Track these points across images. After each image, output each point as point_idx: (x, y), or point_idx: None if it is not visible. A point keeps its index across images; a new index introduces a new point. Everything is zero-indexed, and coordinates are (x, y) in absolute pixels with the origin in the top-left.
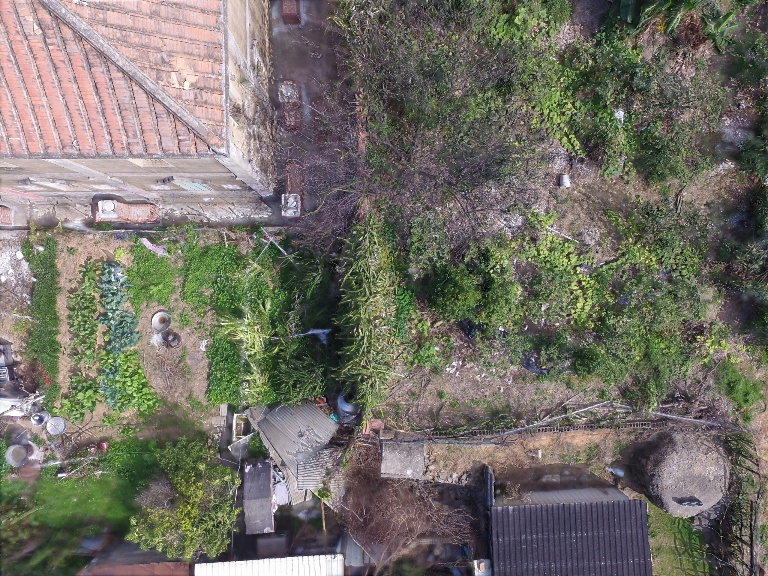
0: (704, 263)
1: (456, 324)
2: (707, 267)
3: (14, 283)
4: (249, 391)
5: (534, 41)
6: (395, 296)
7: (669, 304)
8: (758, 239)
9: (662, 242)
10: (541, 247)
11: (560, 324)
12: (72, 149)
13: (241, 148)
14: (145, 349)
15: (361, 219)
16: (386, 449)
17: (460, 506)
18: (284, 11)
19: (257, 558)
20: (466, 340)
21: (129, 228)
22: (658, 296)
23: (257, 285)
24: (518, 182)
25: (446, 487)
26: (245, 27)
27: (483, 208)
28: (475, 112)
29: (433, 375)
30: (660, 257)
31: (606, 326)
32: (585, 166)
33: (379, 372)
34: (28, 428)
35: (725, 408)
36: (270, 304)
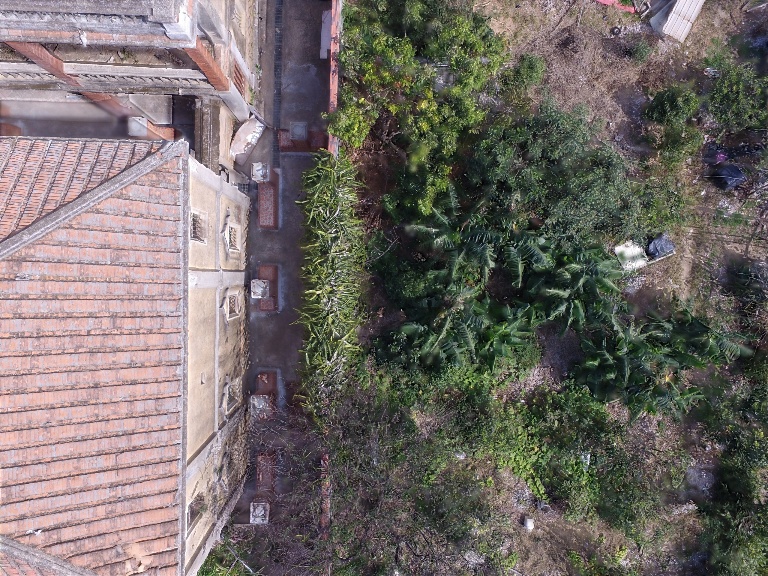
0: None
1: None
2: None
3: None
4: None
5: (504, 384)
6: None
7: None
8: None
9: None
10: None
11: None
12: None
13: (204, 532)
14: None
15: None
16: None
17: None
18: (261, 307)
19: None
20: None
21: None
22: None
23: None
24: None
25: None
26: (214, 396)
27: None
28: (442, 454)
29: None
30: None
31: None
32: None
33: None
34: None
35: None
36: None
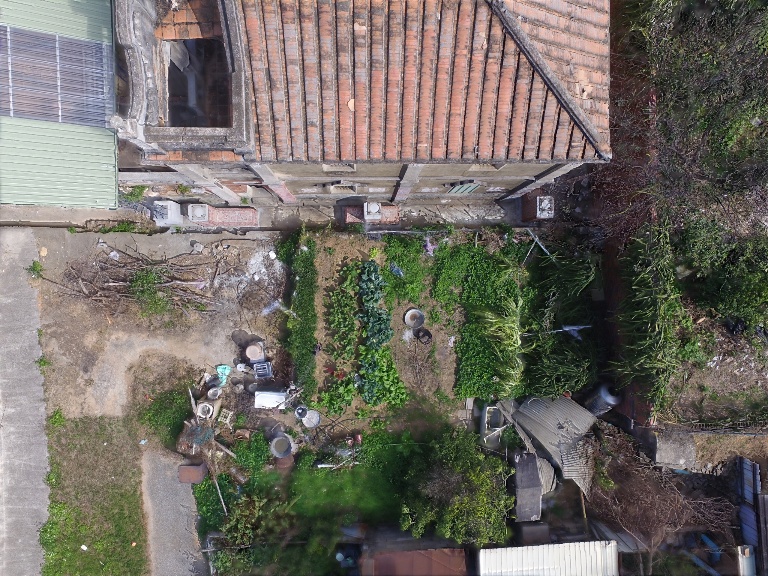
0: None
1: (718, 320)
2: None
3: (267, 282)
4: (512, 385)
5: None
6: None
7: None
8: None
9: None
10: None
11: None
12: (471, 155)
13: None
14: (397, 345)
15: (653, 220)
16: (660, 440)
17: (700, 496)
18: None
19: (537, 544)
20: (727, 336)
21: (372, 229)
22: None
23: (507, 283)
24: None
25: (683, 477)
26: None
27: (744, 210)
28: (741, 118)
29: (694, 369)
30: None
31: None
32: None
33: None
34: (281, 421)
35: None
36: (522, 302)
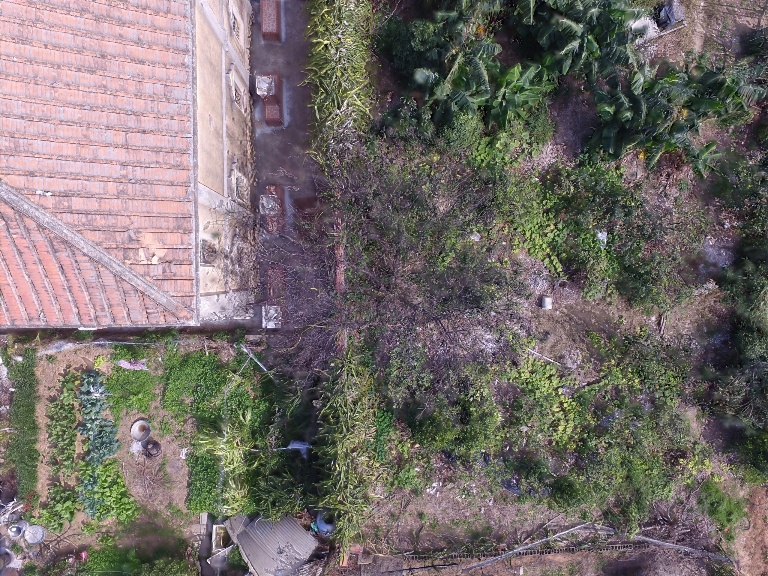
0: (688, 382)
1: None
2: (691, 386)
3: None
4: None
5: (516, 161)
6: (375, 418)
7: (651, 435)
8: (742, 363)
9: (644, 373)
10: (522, 370)
11: (542, 444)
12: (39, 321)
13: (216, 287)
14: (124, 457)
15: (339, 351)
16: (364, 575)
17: None
18: (267, 116)
19: None
20: (446, 461)
21: (110, 331)
22: (640, 426)
23: (237, 394)
24: (500, 303)
25: None
26: (222, 159)
27: (464, 328)
28: (456, 233)
29: (413, 495)
30: (643, 379)
31: (588, 447)
32: (567, 287)
33: (356, 507)
34: (6, 535)
35: (708, 529)
36: (250, 415)
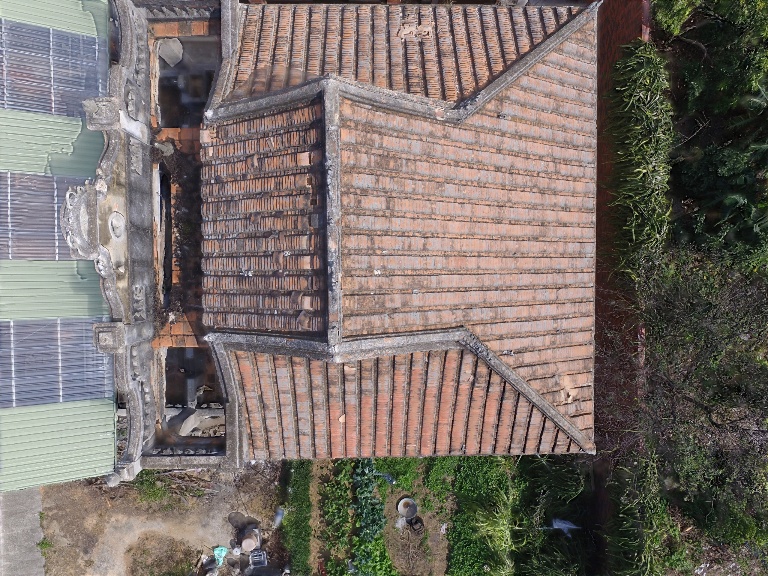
0: None
1: None
2: None
3: (263, 466)
4: None
5: None
6: None
7: None
8: None
9: None
10: None
11: None
12: (459, 452)
13: None
14: (390, 532)
15: (641, 450)
16: None
17: None
18: None
19: None
20: (714, 544)
21: None
22: None
23: (498, 475)
24: None
25: None
26: None
27: None
28: None
29: (681, 575)
30: None
31: None
32: None
33: None
34: None
35: None
36: None
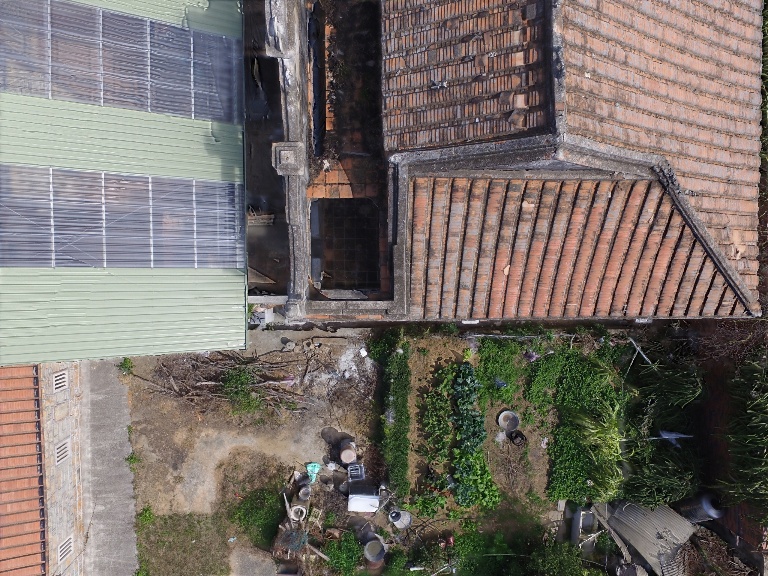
0: None
1: None
2: None
3: (357, 379)
4: None
5: None
6: None
7: None
8: None
9: None
10: None
11: None
12: (620, 313)
13: None
14: (489, 446)
15: None
16: (767, 559)
17: None
18: None
19: None
20: None
21: (462, 325)
22: None
23: (602, 386)
24: None
25: None
26: None
27: None
28: None
29: None
30: None
31: None
32: None
33: None
34: (371, 520)
35: None
36: (619, 406)
